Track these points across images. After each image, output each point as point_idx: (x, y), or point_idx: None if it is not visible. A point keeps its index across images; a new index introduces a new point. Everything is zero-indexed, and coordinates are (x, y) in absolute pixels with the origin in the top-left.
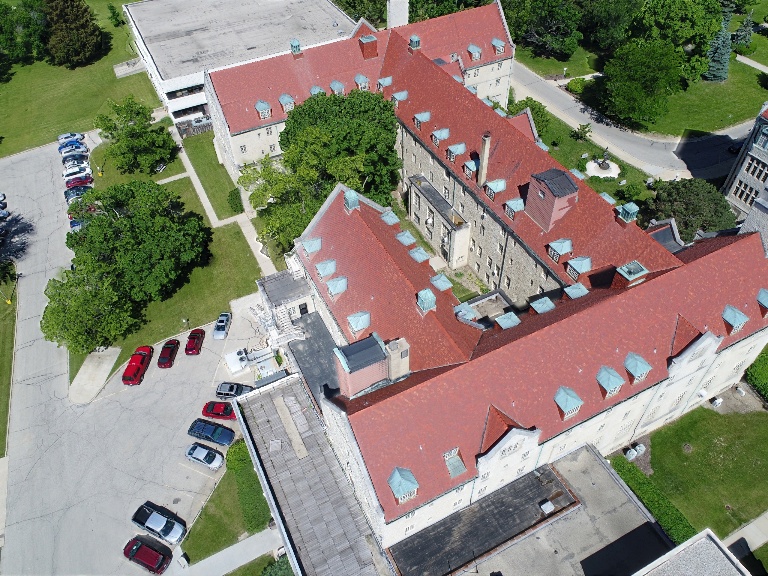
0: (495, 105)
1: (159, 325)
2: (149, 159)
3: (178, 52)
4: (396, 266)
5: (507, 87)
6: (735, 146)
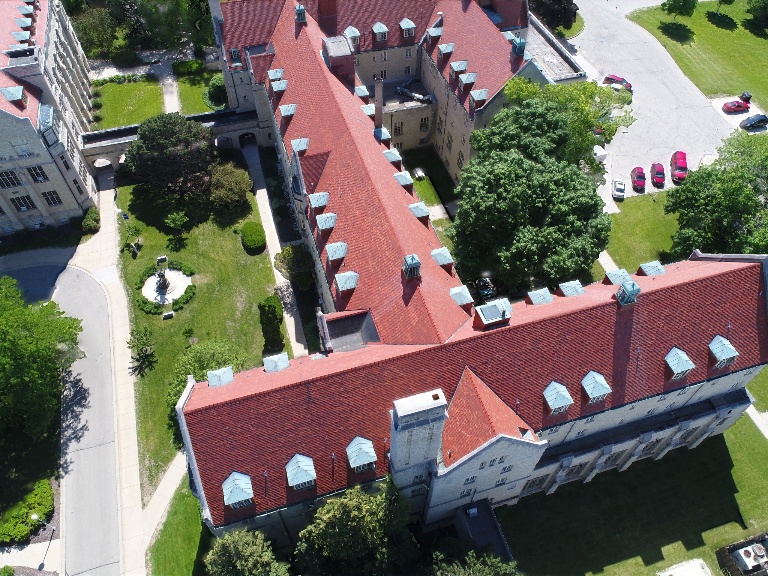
0: None
1: None
2: None
3: None
4: None
5: None
6: None
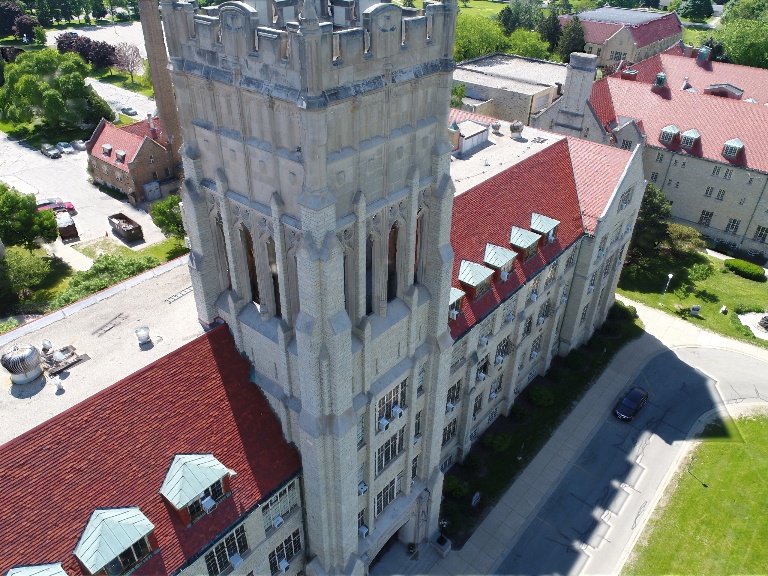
0: None
1: None
2: None
3: None
4: None
5: None
6: (642, 391)
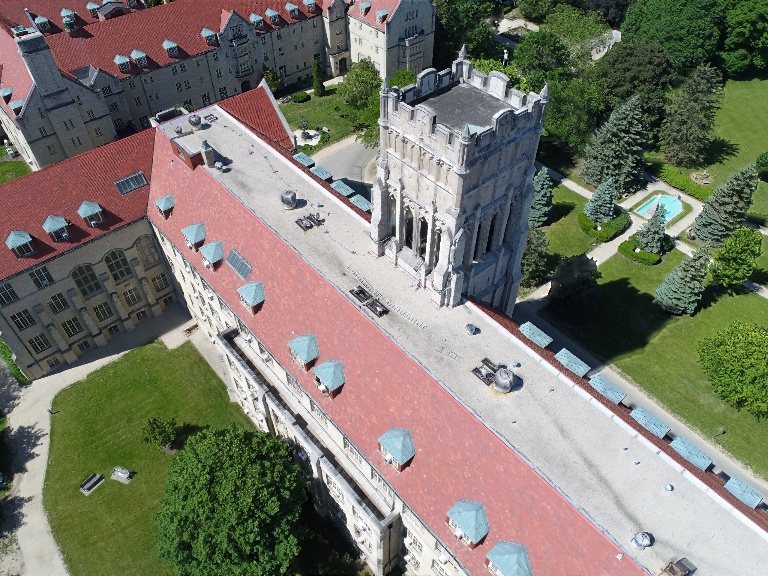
0: (368, 68)
1: None
2: None
3: None
4: None
5: (384, 61)
6: None
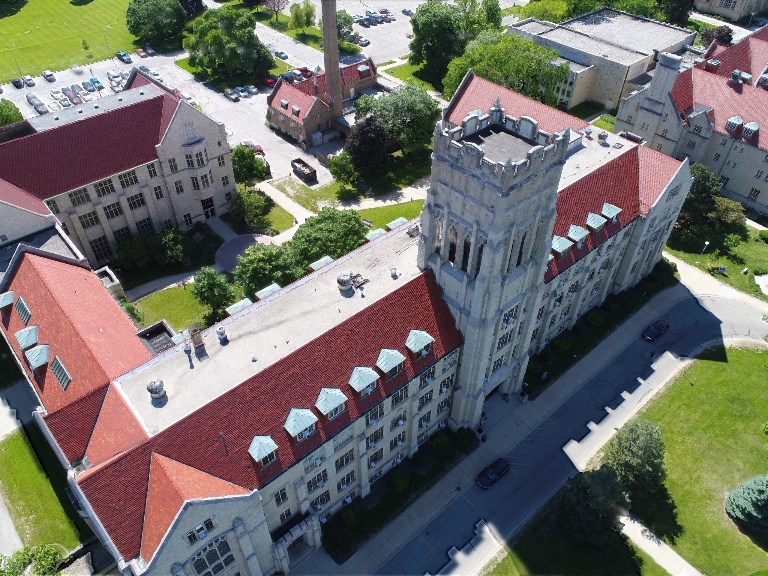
0: None
1: None
2: None
3: None
4: None
5: None
6: (665, 323)
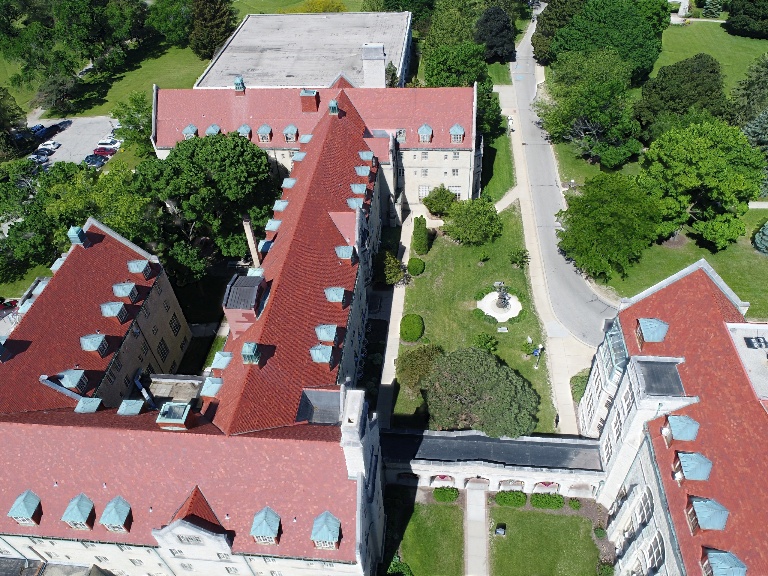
0: (448, 196)
1: (26, 285)
2: (142, 149)
3: (236, 65)
4: (29, 308)
5: (468, 180)
6: None
